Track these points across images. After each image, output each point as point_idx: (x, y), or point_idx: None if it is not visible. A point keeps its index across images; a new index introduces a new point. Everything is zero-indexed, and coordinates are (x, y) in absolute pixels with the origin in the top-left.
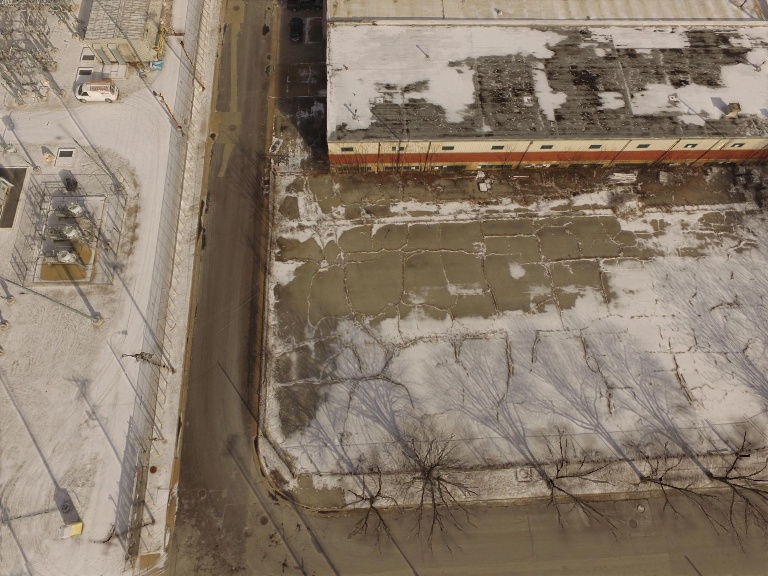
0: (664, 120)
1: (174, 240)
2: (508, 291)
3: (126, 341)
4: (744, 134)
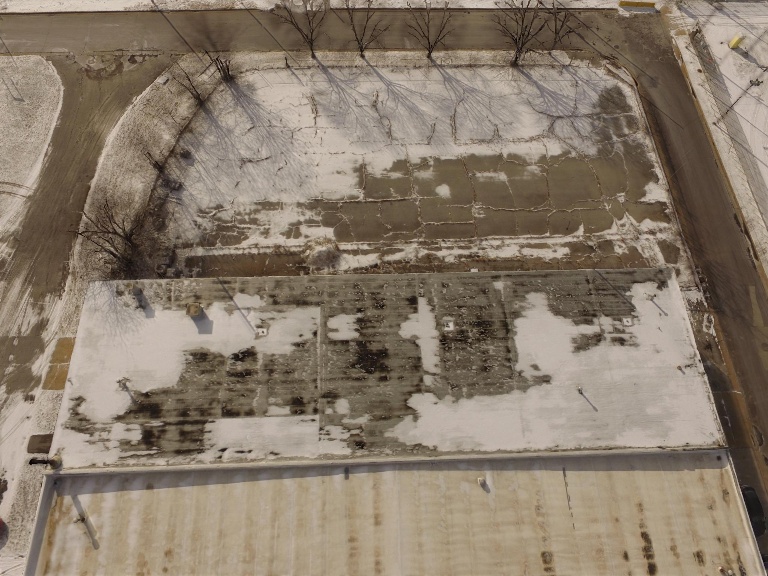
0: (284, 300)
1: (765, 220)
2: (453, 174)
3: (761, 143)
4: (192, 282)
